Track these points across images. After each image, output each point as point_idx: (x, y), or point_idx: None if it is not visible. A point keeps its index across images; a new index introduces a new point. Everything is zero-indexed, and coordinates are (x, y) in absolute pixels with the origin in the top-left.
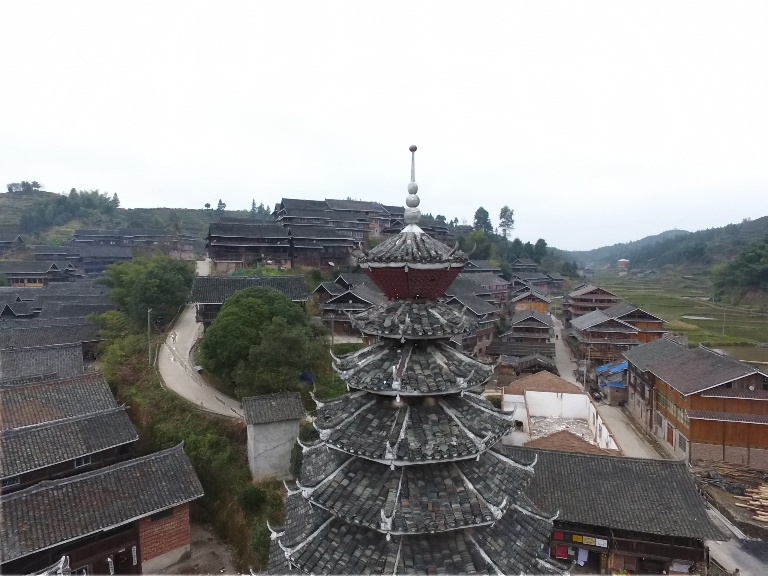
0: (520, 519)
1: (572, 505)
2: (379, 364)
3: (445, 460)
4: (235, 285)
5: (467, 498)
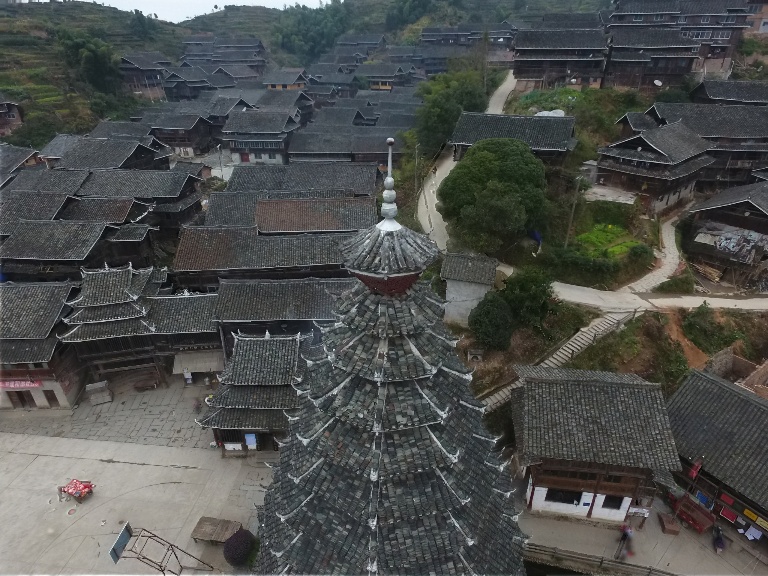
0: (436, 485)
1: (762, 483)
2: (346, 331)
3: None
4: (496, 125)
5: (366, 454)
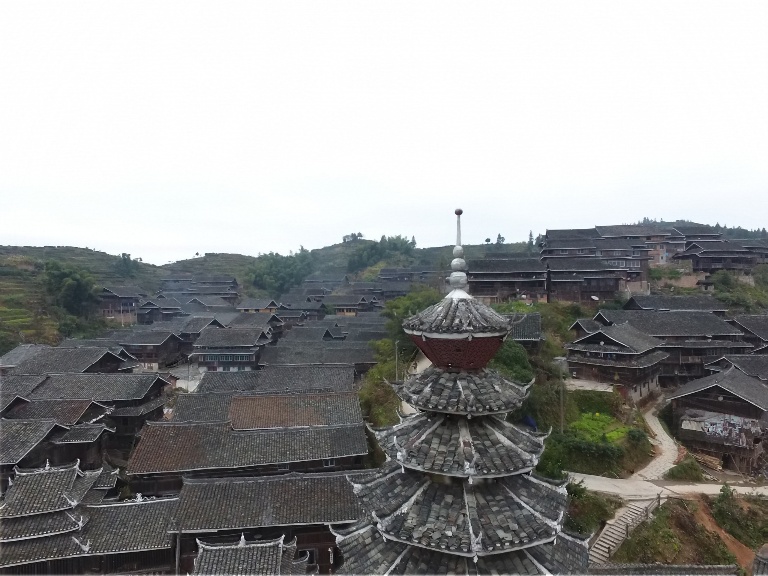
0: None
1: None
2: (410, 430)
3: (436, 549)
4: None
5: None
